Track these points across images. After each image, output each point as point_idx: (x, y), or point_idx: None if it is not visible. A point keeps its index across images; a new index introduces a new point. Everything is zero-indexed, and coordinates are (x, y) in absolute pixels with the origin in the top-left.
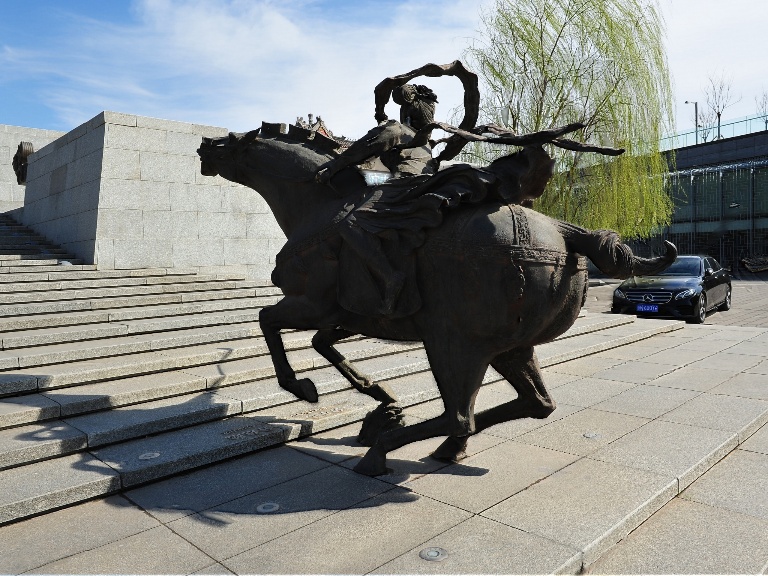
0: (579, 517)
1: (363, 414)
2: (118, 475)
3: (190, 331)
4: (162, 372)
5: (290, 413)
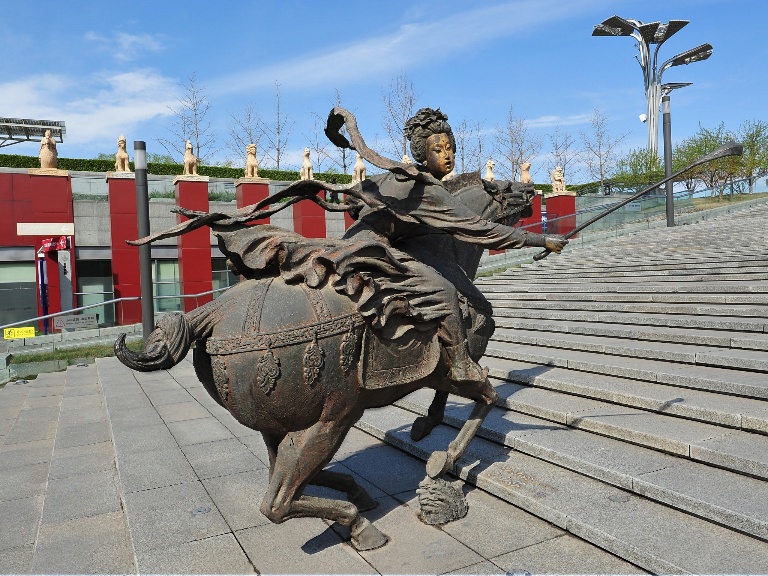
0: (172, 568)
1: (525, 504)
2: (387, 433)
3: (746, 375)
4: (605, 402)
5: (514, 466)
